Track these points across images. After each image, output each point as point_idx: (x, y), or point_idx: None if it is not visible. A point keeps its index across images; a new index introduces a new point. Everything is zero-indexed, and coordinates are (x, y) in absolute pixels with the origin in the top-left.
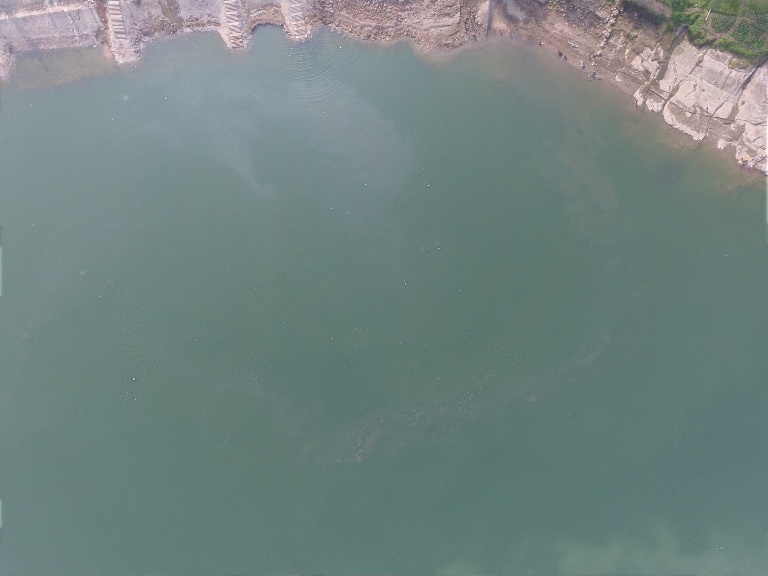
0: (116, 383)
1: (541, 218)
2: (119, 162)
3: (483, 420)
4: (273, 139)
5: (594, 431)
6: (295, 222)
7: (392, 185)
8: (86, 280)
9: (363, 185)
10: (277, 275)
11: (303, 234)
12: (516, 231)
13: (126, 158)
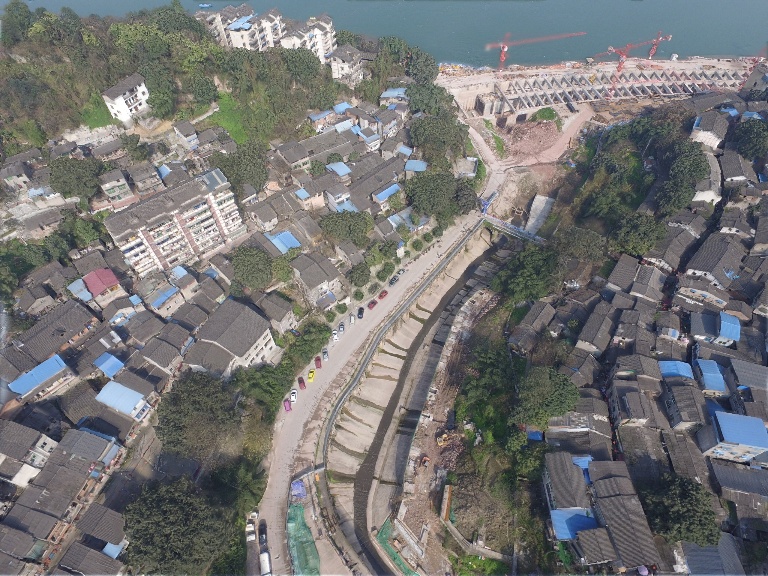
0: (540, 1)
1: (372, 32)
2: (560, 43)
3: (395, 1)
4: (491, 47)
5: (354, 0)
6: (476, 30)
7: (435, 37)
8: (562, 18)
9: (448, 37)
10: (481, 21)
11: (472, 28)
12: (382, 30)
13: (558, 44)
